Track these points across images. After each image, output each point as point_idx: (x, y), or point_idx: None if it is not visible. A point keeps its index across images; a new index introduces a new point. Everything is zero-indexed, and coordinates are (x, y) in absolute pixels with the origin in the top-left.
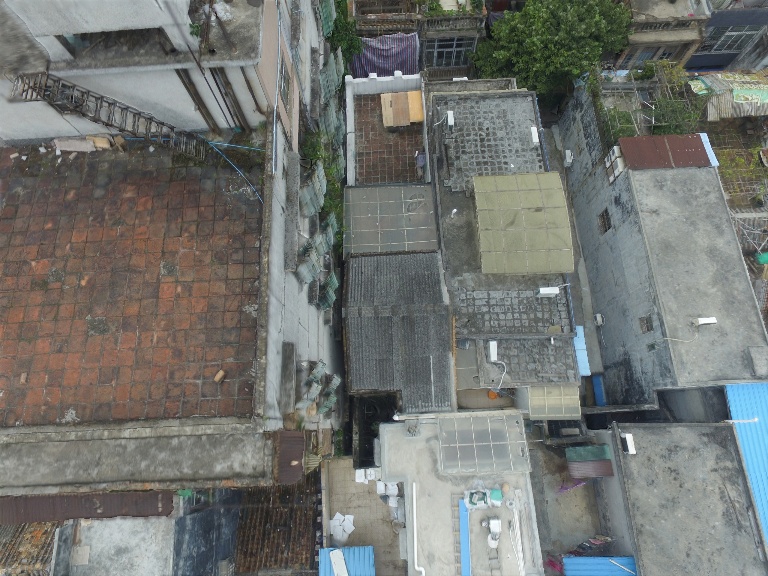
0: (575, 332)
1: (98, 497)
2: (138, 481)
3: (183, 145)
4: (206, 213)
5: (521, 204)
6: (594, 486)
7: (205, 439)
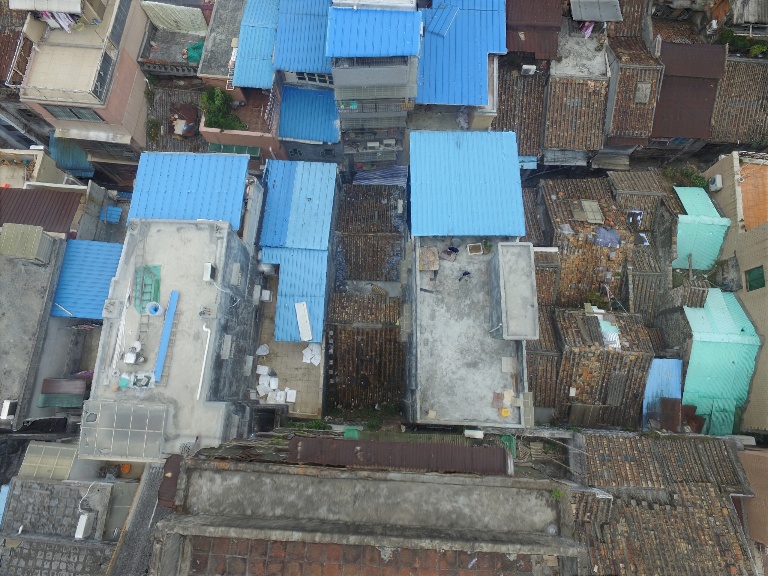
0: None
1: (358, 462)
2: None
3: None
4: None
5: None
6: (78, 368)
7: (247, 511)
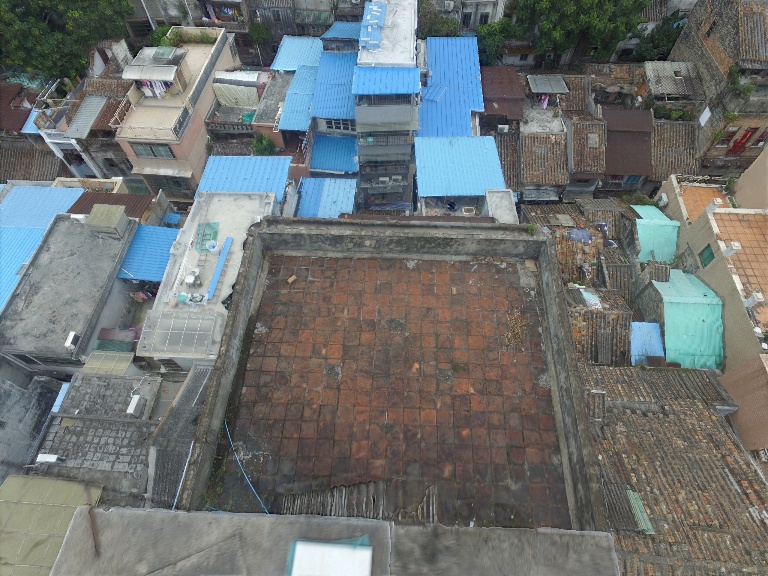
0: (50, 415)
1: None
2: (356, 224)
3: (297, 505)
4: (292, 429)
5: (11, 572)
6: None
7: None
